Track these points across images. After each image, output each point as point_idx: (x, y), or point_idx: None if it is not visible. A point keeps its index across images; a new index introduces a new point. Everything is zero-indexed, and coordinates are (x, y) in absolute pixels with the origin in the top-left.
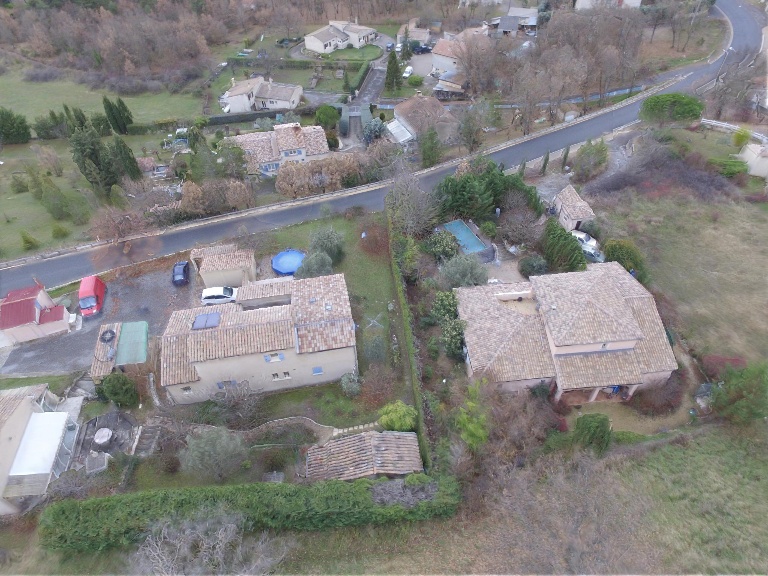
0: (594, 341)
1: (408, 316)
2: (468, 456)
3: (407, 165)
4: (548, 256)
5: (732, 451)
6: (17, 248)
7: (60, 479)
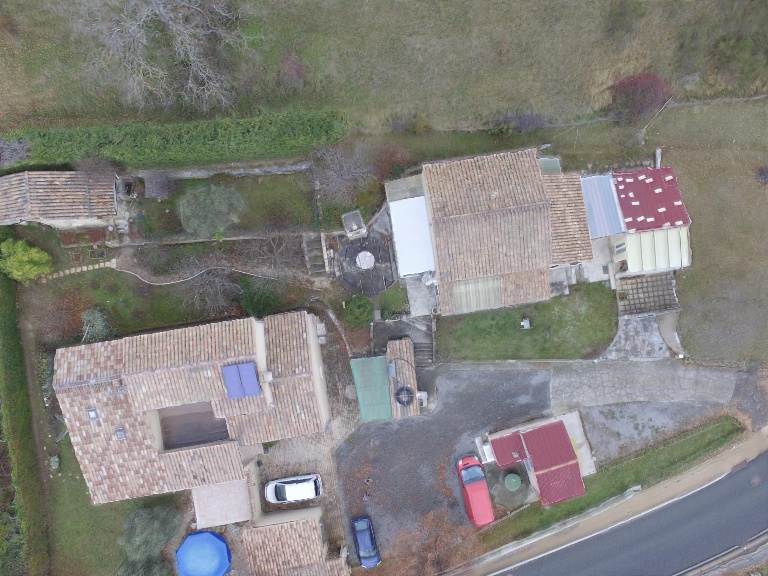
0: None
1: (4, 416)
2: None
3: None
4: None
5: None
6: None
7: (366, 187)
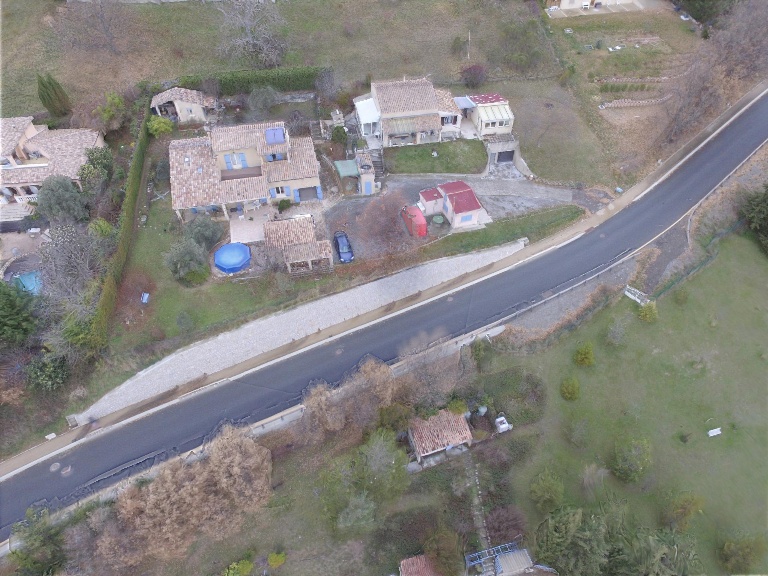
0: (5, 118)
1: None
2: (126, 102)
3: (15, 574)
4: None
5: None
6: (599, 352)
7: (343, 95)
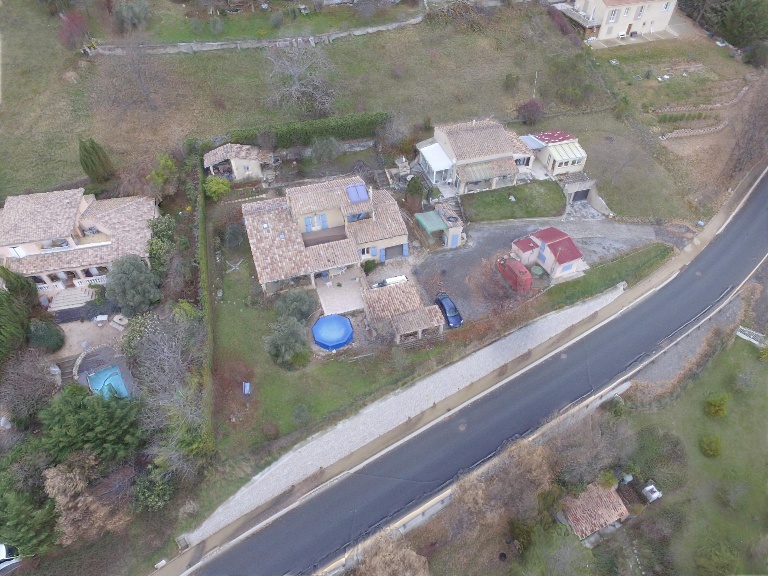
0: None
1: None
2: (176, 163)
3: None
4: (22, 329)
5: (5, 187)
6: (728, 400)
7: (407, 141)
